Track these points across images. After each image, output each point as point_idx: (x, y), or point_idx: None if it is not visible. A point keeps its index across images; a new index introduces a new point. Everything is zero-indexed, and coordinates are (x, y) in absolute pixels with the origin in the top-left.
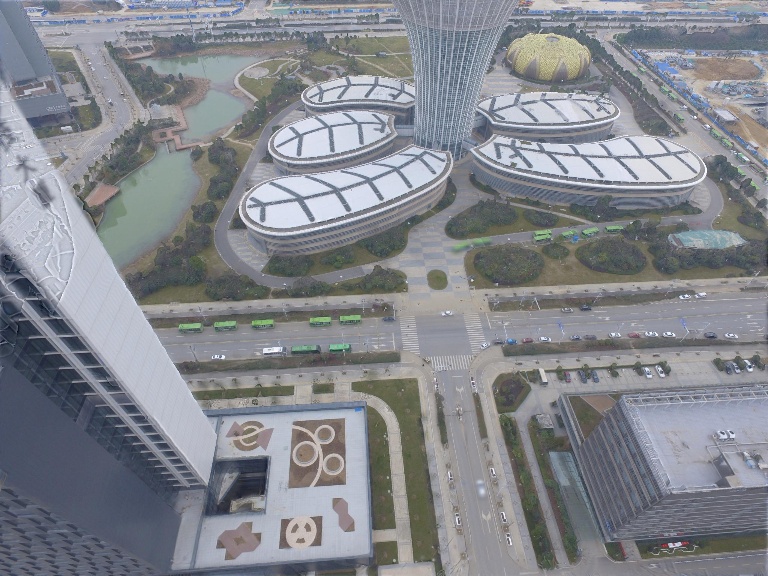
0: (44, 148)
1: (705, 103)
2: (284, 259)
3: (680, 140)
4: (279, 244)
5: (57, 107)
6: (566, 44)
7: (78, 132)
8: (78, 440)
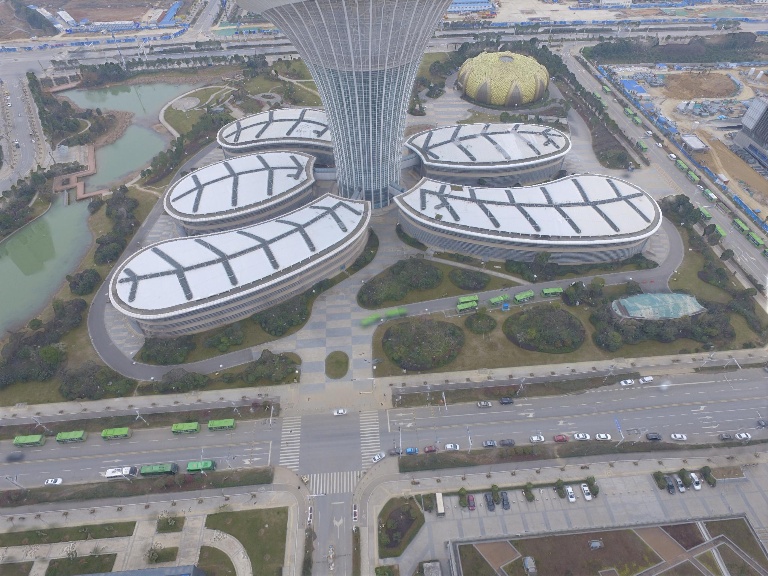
0: None
1: (672, 128)
2: (162, 342)
3: (641, 173)
4: (153, 326)
5: None
6: (520, 64)
7: None
8: None
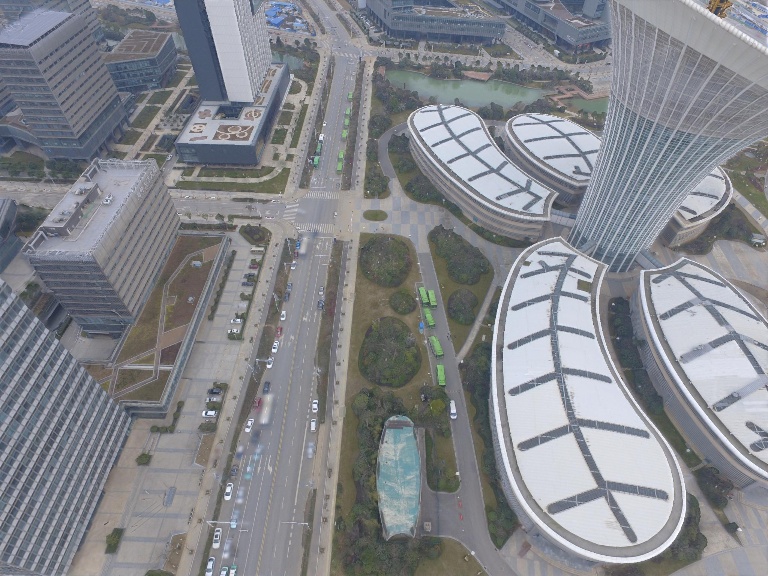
0: (532, 51)
1: None
2: (405, 142)
3: None
4: None
5: (571, 38)
6: None
7: (557, 58)
8: (193, 1)
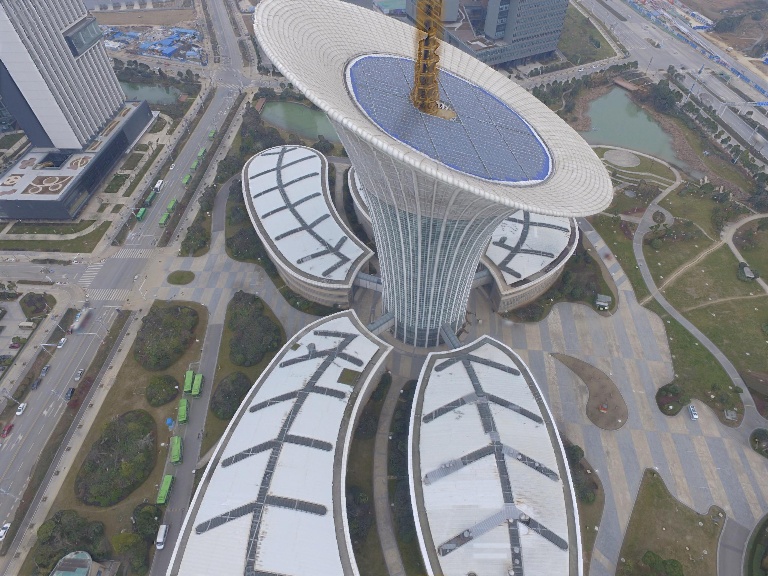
0: None
1: None
2: None
3: None
4: None
5: None
6: None
7: None
8: None
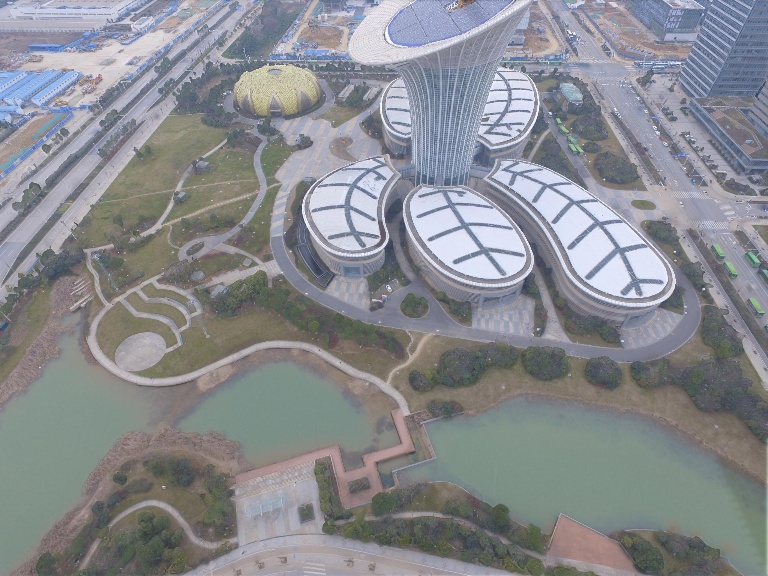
0: None
1: None
2: None
3: None
4: None
5: None
6: (289, 69)
7: None
8: None
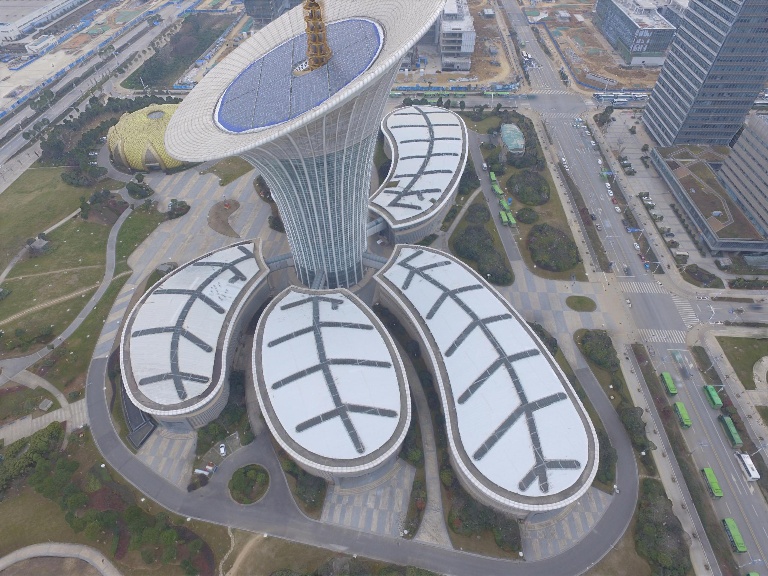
0: None
1: None
2: None
3: None
4: None
5: None
6: None
7: None
8: None
